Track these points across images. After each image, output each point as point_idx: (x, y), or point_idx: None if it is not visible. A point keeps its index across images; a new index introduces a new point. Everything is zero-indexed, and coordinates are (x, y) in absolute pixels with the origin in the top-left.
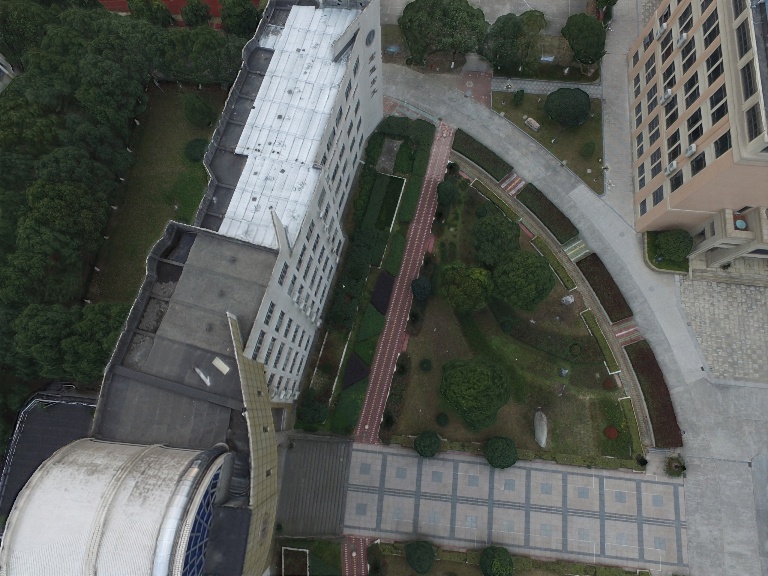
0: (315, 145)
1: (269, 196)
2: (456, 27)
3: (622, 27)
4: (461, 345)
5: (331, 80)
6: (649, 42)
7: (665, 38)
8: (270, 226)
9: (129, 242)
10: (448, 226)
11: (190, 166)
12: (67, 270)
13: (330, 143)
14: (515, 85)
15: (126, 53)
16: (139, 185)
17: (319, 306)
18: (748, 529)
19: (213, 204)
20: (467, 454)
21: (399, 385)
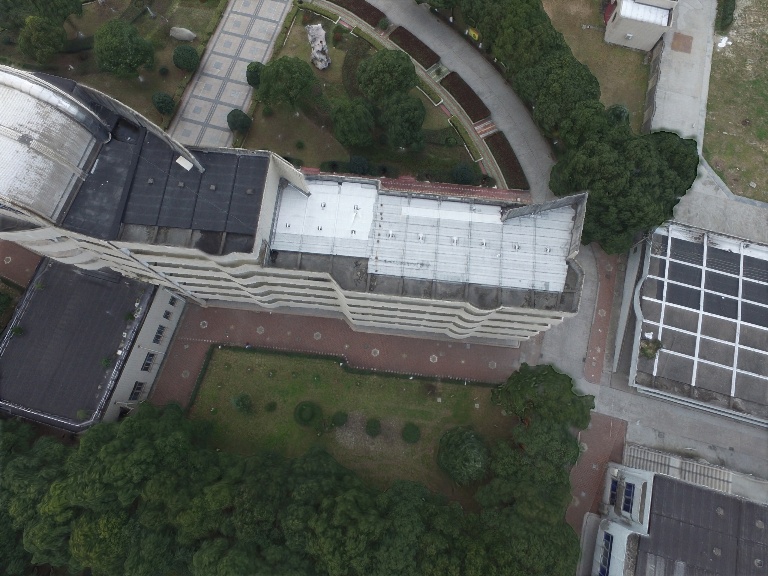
0: None
1: None
2: None
3: None
4: (107, 76)
5: None
6: None
7: None
8: None
9: None
10: None
11: None
12: None
13: None
14: None
15: None
16: None
17: None
18: None
19: None
20: (188, 88)
21: None
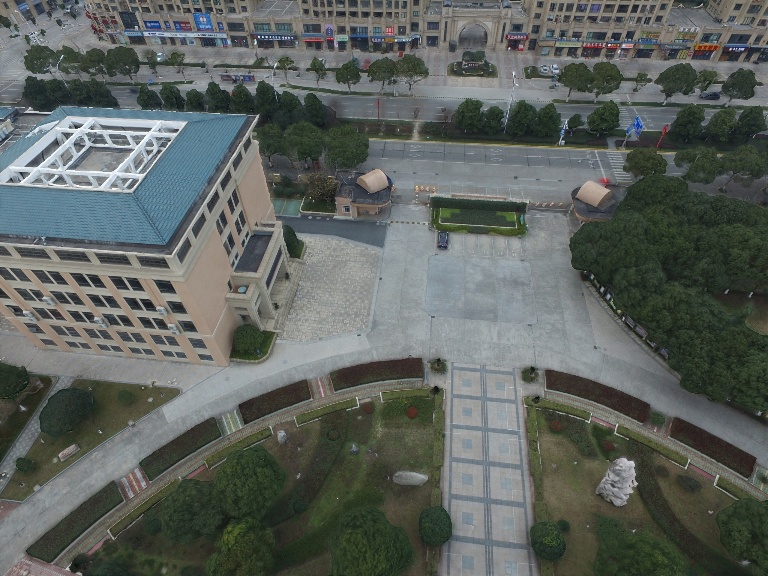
0: None
1: None
2: None
3: (6, 349)
4: (315, 568)
5: None
6: (36, 328)
7: (39, 314)
8: None
9: None
10: None
11: None
12: None
13: None
14: (7, 468)
15: None
16: None
17: None
18: (480, 326)
19: None
20: (440, 569)
21: None
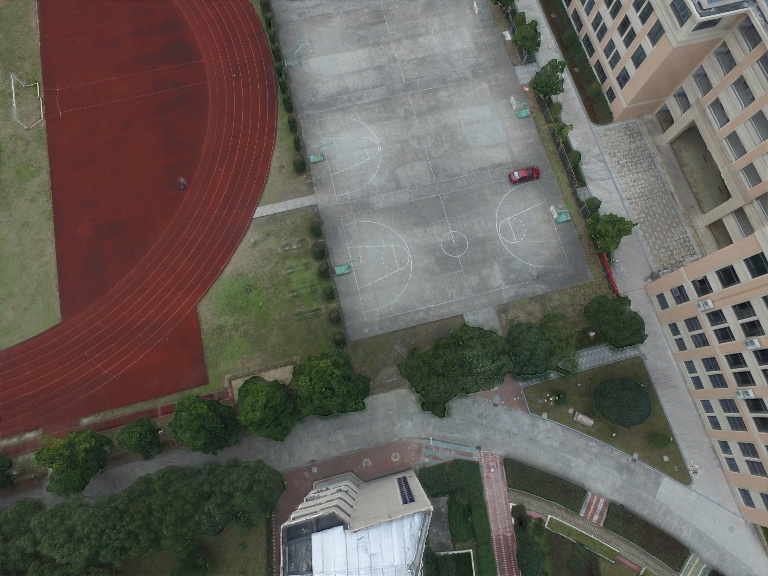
0: None
1: None
2: (478, 374)
3: (626, 254)
4: None
5: None
6: (681, 297)
7: (712, 312)
8: None
9: None
10: None
11: None
12: None
13: None
14: None
15: None
16: None
17: None
18: None
19: None
20: None
21: None
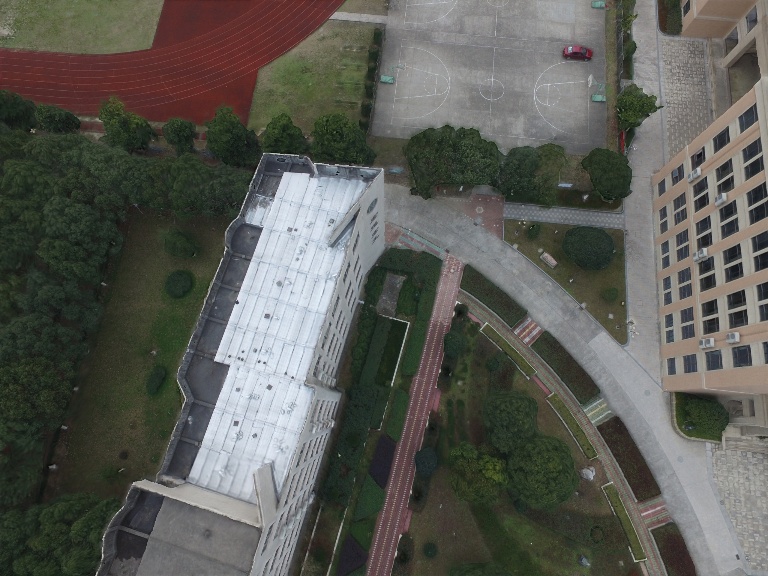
0: (307, 354)
1: (253, 420)
2: (467, 164)
3: (646, 145)
4: (470, 525)
5: (327, 270)
6: (678, 177)
7: (698, 183)
8: (254, 460)
9: (101, 393)
10: (455, 379)
11: (171, 303)
12: (25, 459)
13: (325, 337)
14: (529, 212)
15: (98, 191)
16: (114, 324)
17: (312, 482)
18: None
19: (188, 426)
20: None
21: (400, 575)
